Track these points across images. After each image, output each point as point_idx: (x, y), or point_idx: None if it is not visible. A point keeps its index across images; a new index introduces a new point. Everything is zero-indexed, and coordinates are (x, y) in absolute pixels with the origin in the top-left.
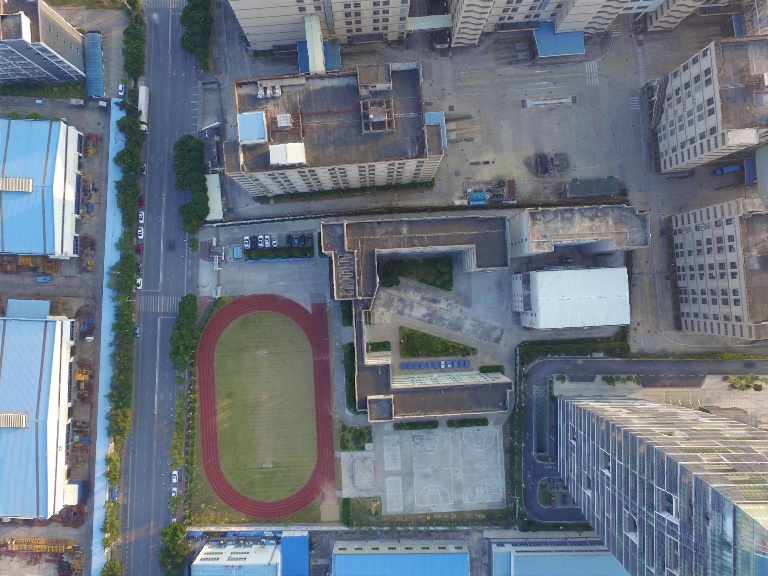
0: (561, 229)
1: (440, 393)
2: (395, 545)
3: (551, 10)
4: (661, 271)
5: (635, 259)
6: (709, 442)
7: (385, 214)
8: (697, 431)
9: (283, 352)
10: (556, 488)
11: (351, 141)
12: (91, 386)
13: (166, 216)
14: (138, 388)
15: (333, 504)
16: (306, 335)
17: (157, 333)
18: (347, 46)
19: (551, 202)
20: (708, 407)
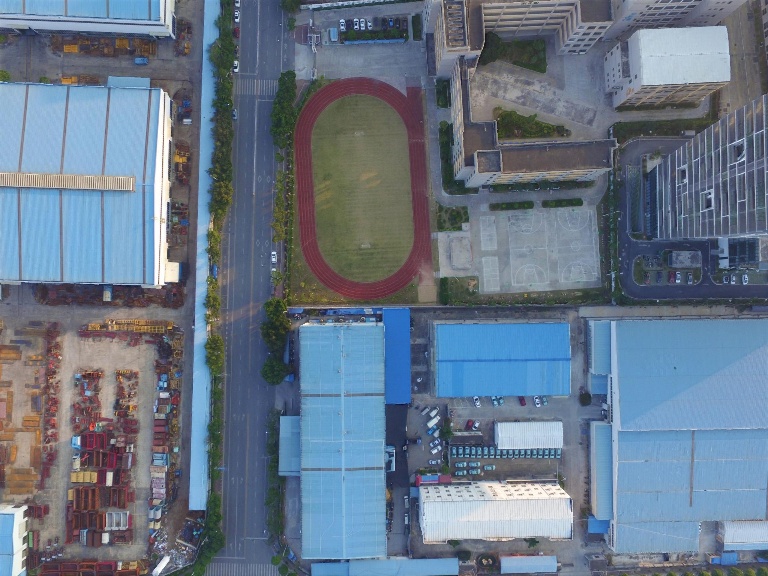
0: None
1: (545, 151)
2: (493, 322)
3: None
4: (750, 53)
5: None
6: None
7: None
8: None
9: (379, 135)
10: (651, 265)
11: None
12: (189, 168)
13: (261, 0)
14: (236, 170)
15: (430, 285)
16: (401, 118)
17: (255, 115)
18: None
19: None
20: None
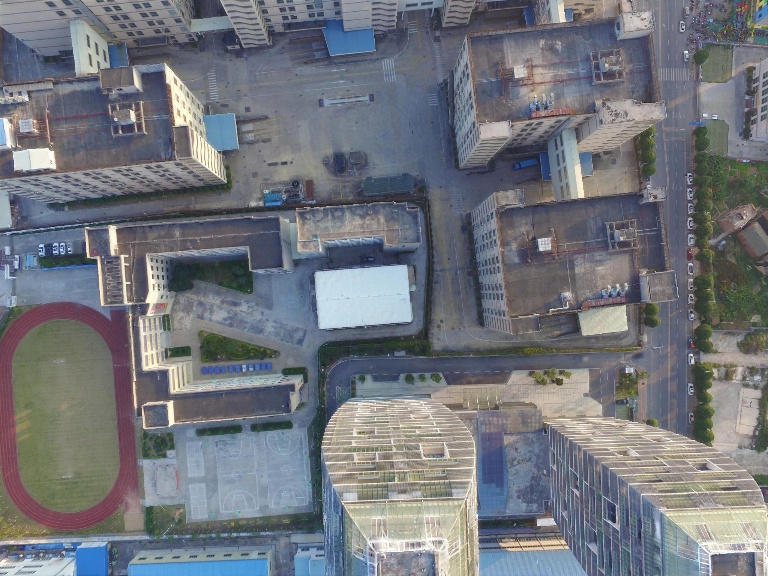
0: (332, 228)
1: (222, 397)
2: (198, 553)
3: (331, 8)
4: (463, 267)
5: (437, 256)
6: (385, 440)
7: (182, 218)
8: (395, 429)
9: (82, 360)
10: None
11: (102, 145)
12: None
13: None
14: None
15: (137, 513)
16: (105, 342)
17: None
18: (140, 50)
19: (348, 201)
20: (503, 403)
